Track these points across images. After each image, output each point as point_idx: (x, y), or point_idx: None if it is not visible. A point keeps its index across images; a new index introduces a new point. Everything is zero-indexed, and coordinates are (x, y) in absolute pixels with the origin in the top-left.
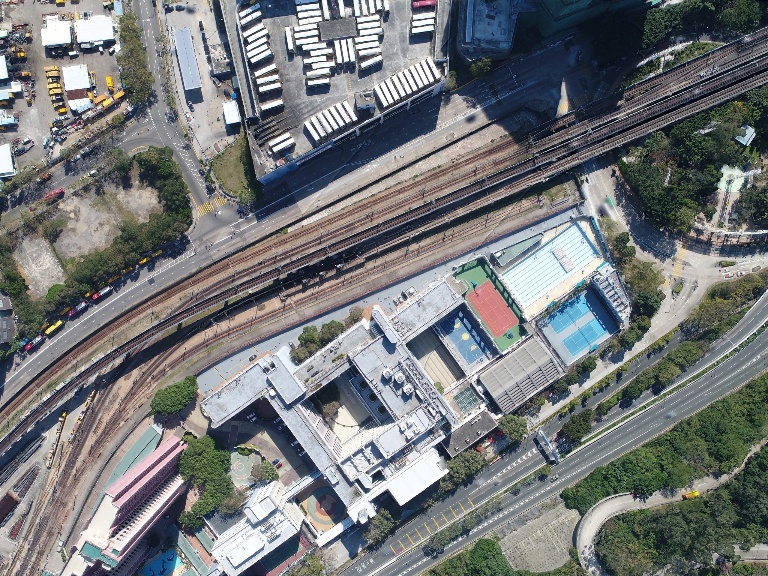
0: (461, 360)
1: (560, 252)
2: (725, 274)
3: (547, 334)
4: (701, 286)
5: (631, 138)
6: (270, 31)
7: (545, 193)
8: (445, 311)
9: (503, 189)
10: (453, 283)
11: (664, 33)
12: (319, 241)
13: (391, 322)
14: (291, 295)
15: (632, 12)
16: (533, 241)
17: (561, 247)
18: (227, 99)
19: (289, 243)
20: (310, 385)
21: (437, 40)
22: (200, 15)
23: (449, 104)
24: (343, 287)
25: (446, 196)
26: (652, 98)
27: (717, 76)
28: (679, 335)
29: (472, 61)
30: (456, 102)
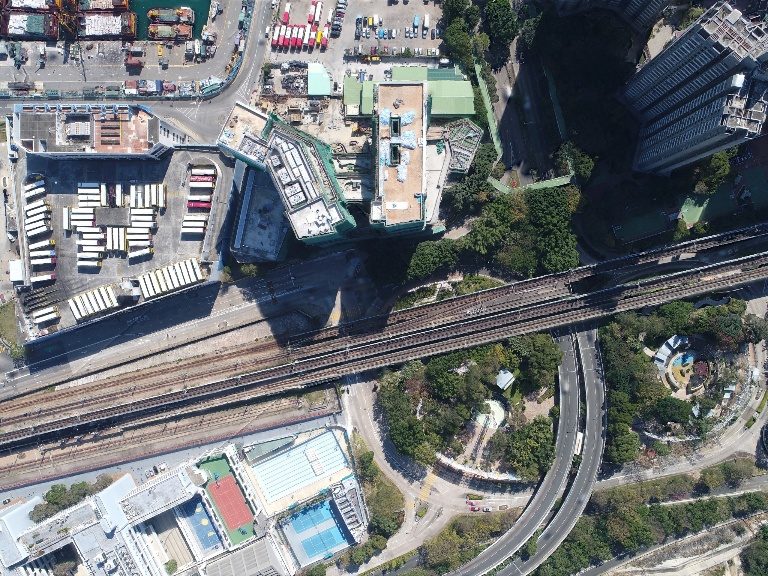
0: (197, 543)
1: (312, 455)
2: (471, 507)
3: (287, 532)
4: (445, 514)
5: (390, 362)
6: (53, 206)
7: (305, 396)
8: (174, 503)
9: (260, 388)
10: (192, 473)
11: (432, 268)
12: (82, 404)
13: (121, 504)
14: (51, 449)
15: (412, 237)
16: (283, 442)
17: (314, 450)
18: (18, 255)
19: (54, 401)
20: (34, 551)
21: (213, 237)
22: (5, 171)
23: (226, 294)
24: (100, 451)
25: (202, 387)
26: (416, 326)
27: (482, 317)
28: (417, 557)
29: (242, 264)
30: (233, 293)
